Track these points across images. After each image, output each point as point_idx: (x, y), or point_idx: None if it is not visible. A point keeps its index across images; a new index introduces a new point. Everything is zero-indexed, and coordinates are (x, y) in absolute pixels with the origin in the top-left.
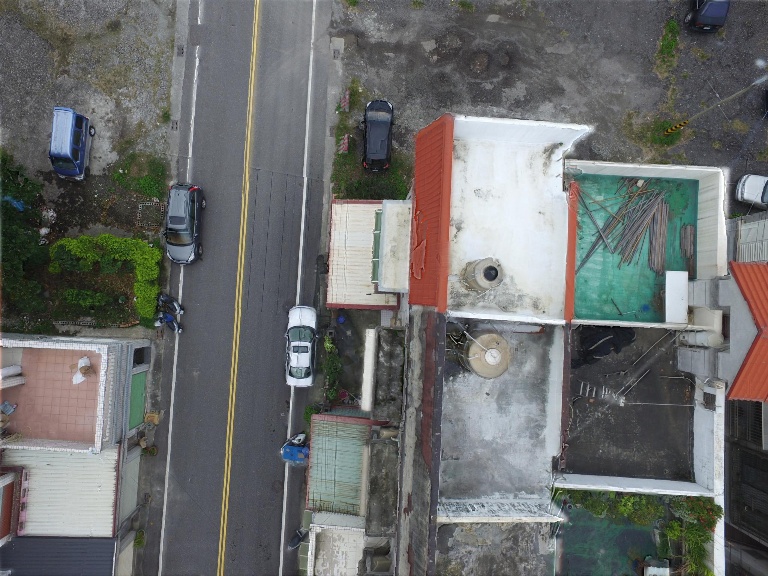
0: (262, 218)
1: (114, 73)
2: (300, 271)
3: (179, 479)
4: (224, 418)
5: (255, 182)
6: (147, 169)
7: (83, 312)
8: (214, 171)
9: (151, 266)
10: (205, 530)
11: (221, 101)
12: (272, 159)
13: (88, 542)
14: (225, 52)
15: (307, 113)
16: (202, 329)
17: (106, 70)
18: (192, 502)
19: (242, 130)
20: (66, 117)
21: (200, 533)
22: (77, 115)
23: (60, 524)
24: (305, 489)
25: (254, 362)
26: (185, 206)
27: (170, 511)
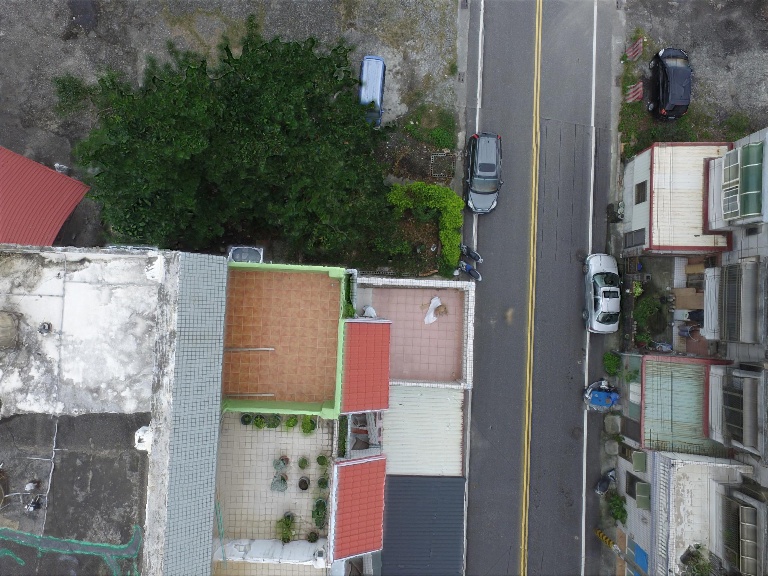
0: (553, 168)
1: (401, 26)
2: (591, 220)
3: (480, 427)
4: (523, 366)
5: (544, 132)
6: (437, 120)
7: (381, 262)
8: (503, 122)
9: (457, 214)
10: (508, 477)
11: (508, 52)
12: (560, 109)
13: (441, 481)
14: (510, 3)
15: (593, 63)
16: (497, 278)
17: (392, 23)
18: (494, 449)
19: (530, 80)
20: (377, 66)
21: (503, 480)
22: (384, 64)
23: (414, 463)
24: (604, 436)
25: (550, 310)
26: (497, 153)
27: (472, 458)
